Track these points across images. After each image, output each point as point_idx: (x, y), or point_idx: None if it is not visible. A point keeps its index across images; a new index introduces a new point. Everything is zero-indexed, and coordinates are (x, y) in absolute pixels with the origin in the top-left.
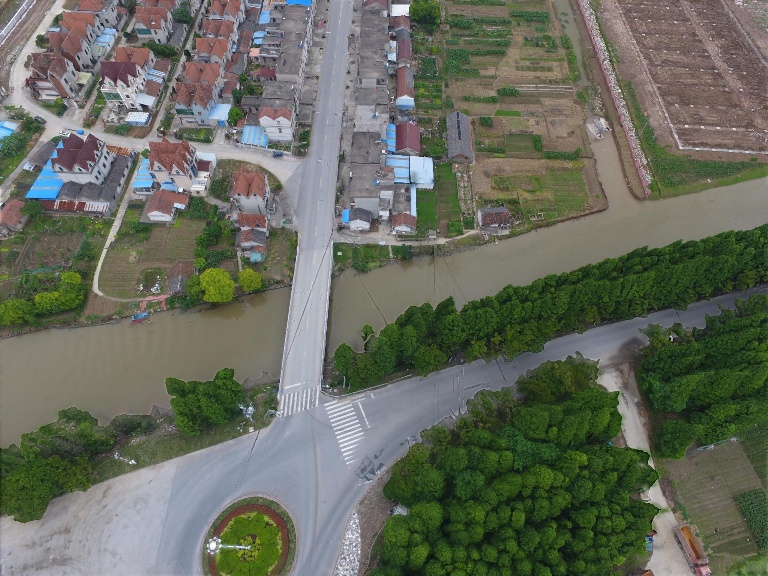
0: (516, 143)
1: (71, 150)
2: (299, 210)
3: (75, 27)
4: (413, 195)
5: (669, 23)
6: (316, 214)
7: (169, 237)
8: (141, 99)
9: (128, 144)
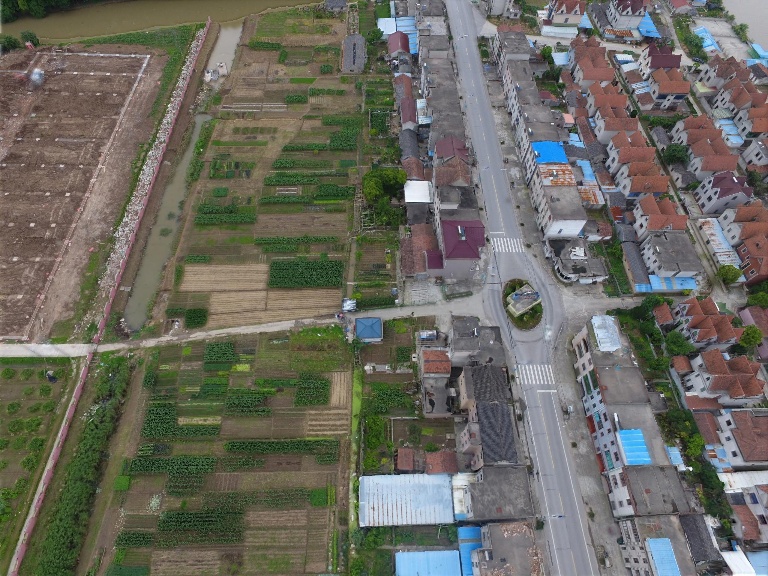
0: (303, 57)
1: (633, 0)
2: (470, 7)
3: (751, 100)
4: (393, 12)
5: (6, 218)
6: (458, 5)
7: (544, 0)
8: (633, 66)
9: (616, 46)
